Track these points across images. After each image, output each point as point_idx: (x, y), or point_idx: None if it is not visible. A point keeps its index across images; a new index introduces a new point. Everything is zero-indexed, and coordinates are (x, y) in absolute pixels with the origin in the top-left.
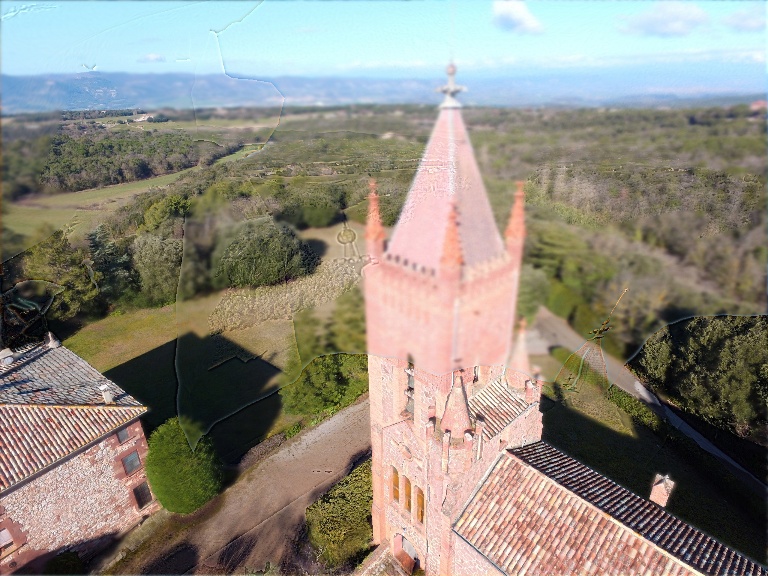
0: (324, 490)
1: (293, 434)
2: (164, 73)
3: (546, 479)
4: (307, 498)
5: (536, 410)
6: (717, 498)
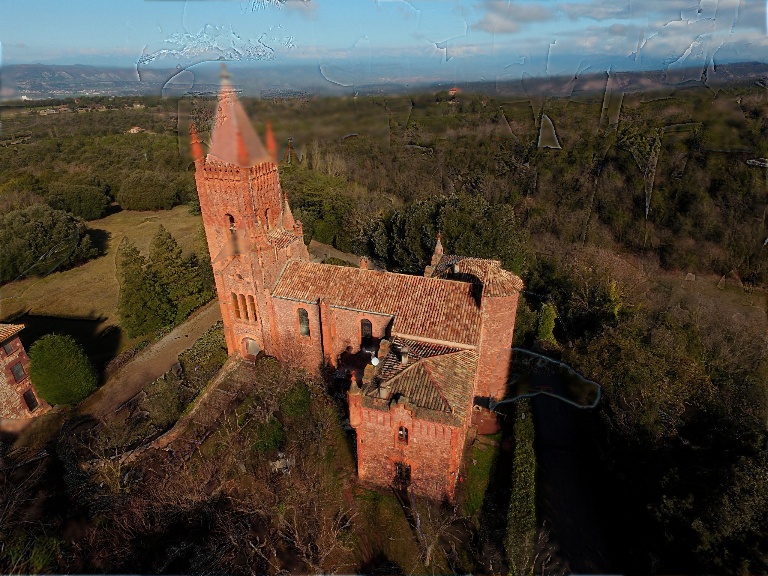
0: None
1: (142, 348)
2: (111, 67)
3: (310, 263)
4: None
5: (302, 242)
6: None
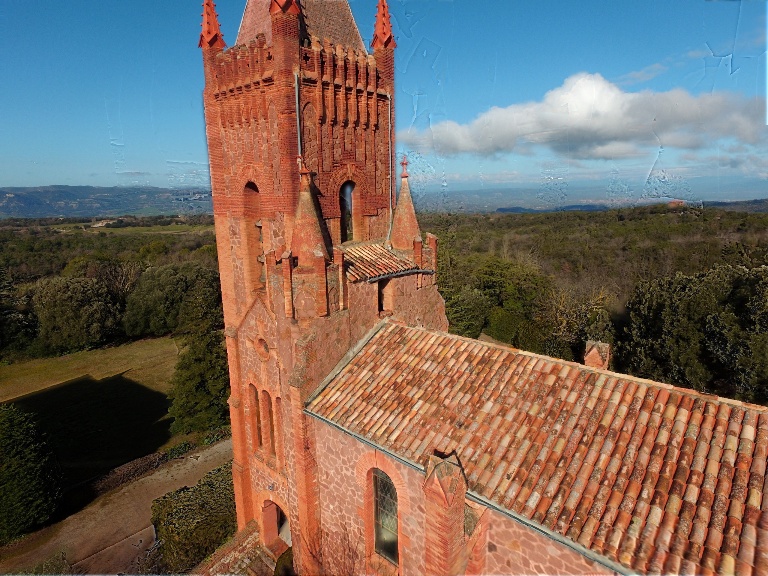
0: None
1: (178, 454)
2: None
3: (437, 333)
4: None
5: (433, 287)
6: None
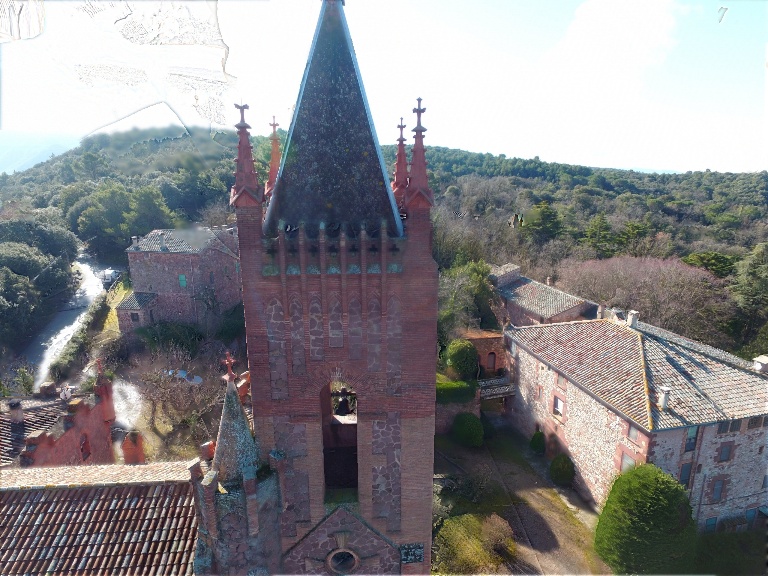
0: None
1: None
2: None
3: None
4: None
5: None
6: None
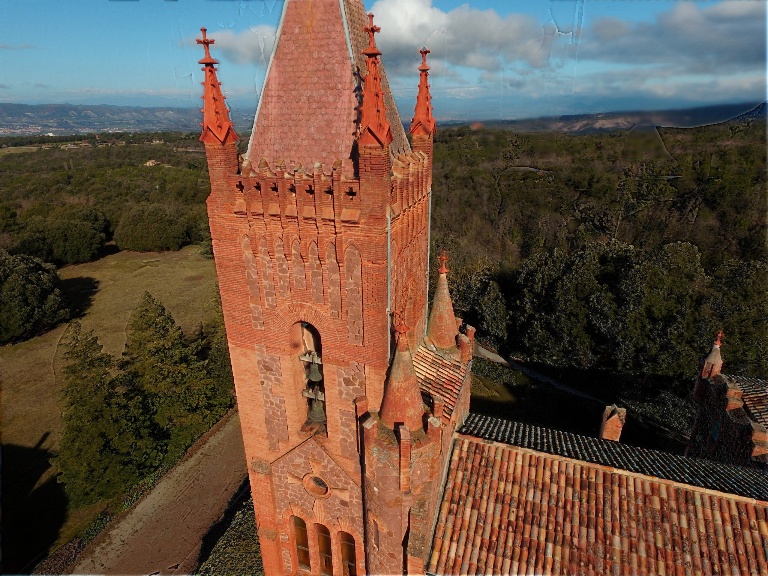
0: None
1: (95, 533)
2: None
3: (521, 451)
4: None
5: None
6: (587, 429)
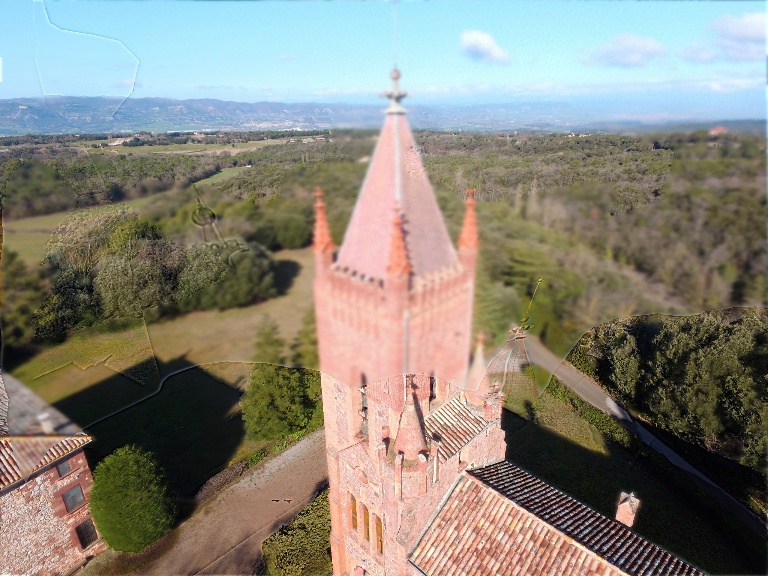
0: (286, 521)
1: (256, 462)
2: None
3: (506, 501)
4: (268, 530)
5: (497, 428)
6: (689, 515)
